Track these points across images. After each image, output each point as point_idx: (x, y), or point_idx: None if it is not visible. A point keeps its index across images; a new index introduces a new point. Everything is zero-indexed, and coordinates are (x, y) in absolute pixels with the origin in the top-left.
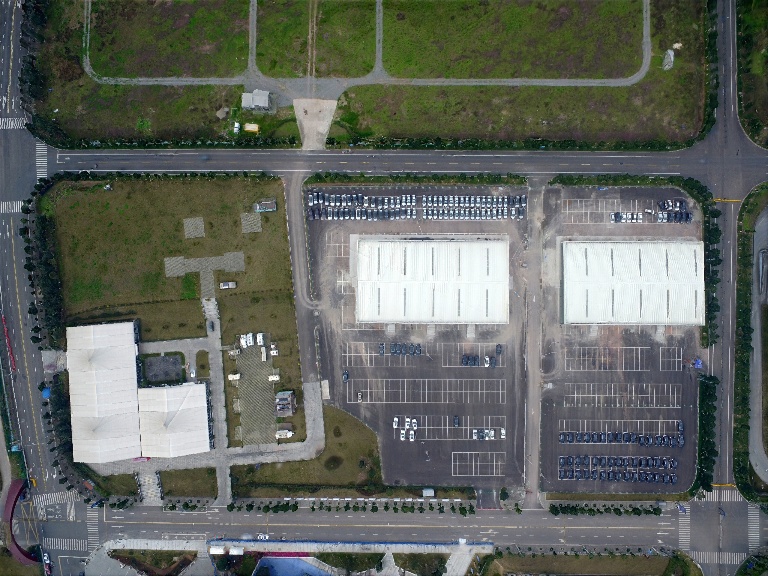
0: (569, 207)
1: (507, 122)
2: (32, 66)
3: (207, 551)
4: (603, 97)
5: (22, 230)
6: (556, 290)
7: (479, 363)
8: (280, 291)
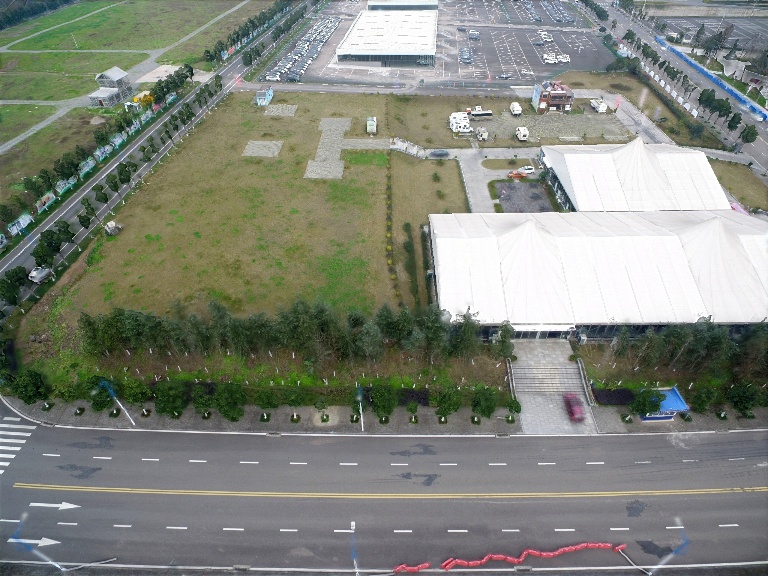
0: None
1: (253, 18)
2: None
3: None
4: None
5: (93, 379)
6: None
7: None
8: None
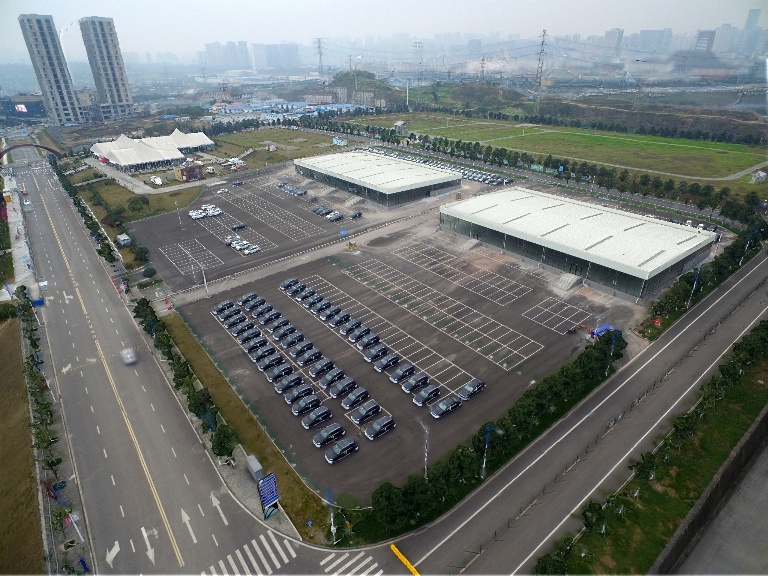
0: None
1: None
2: (333, 113)
3: None
4: (656, 175)
5: None
6: None
7: None
8: None
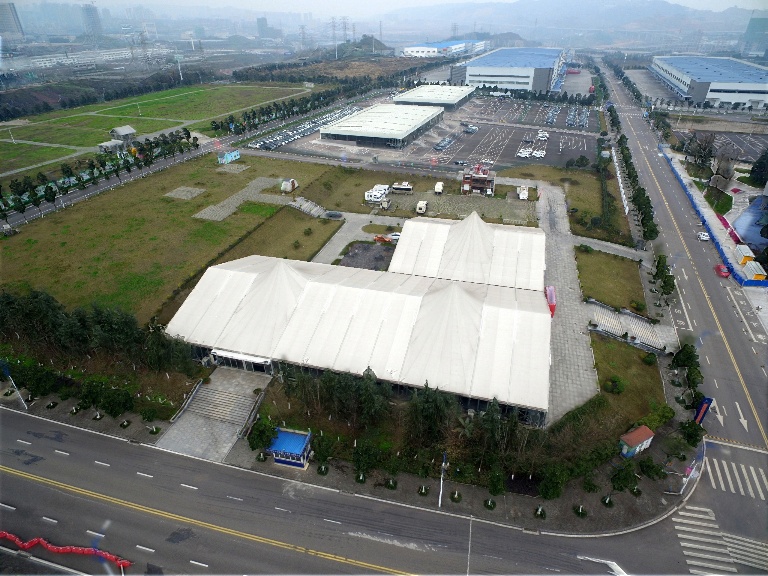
0: (370, 103)
1: None
2: None
3: (763, 280)
4: (310, 93)
5: None
6: None
7: None
8: (331, 170)
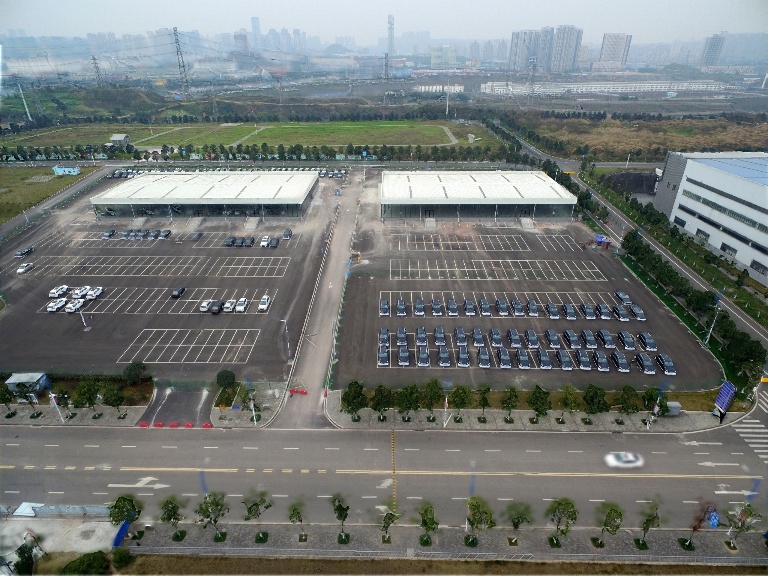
0: None
1: None
2: None
3: None
4: None
5: None
6: (377, 205)
7: (253, 246)
8: (19, 204)
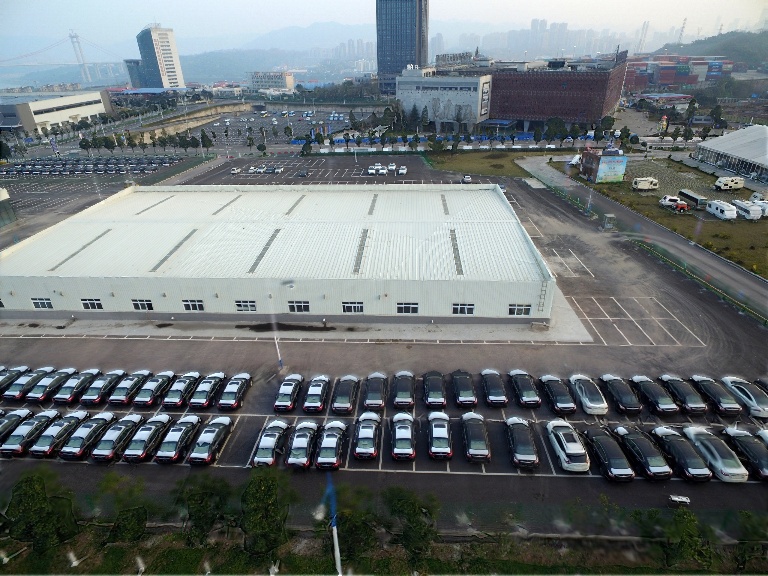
0: None
1: None
2: None
3: (631, 132)
4: None
5: None
6: None
7: None
8: (750, 248)
